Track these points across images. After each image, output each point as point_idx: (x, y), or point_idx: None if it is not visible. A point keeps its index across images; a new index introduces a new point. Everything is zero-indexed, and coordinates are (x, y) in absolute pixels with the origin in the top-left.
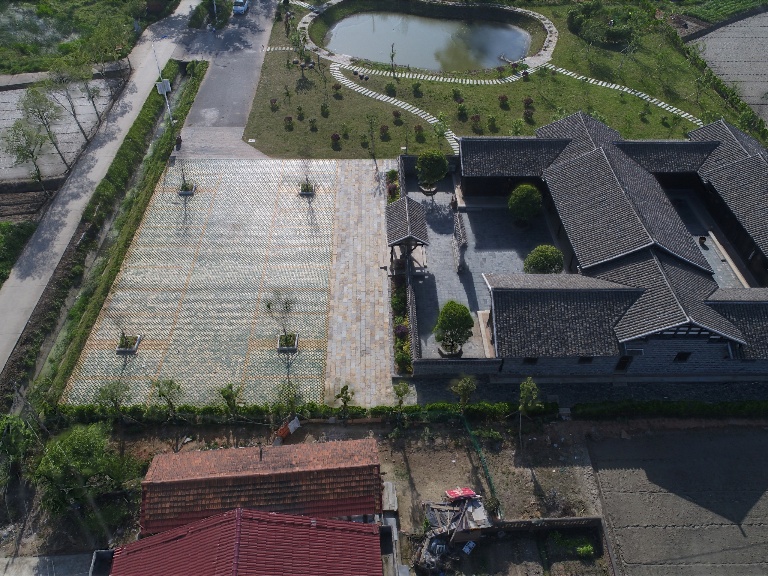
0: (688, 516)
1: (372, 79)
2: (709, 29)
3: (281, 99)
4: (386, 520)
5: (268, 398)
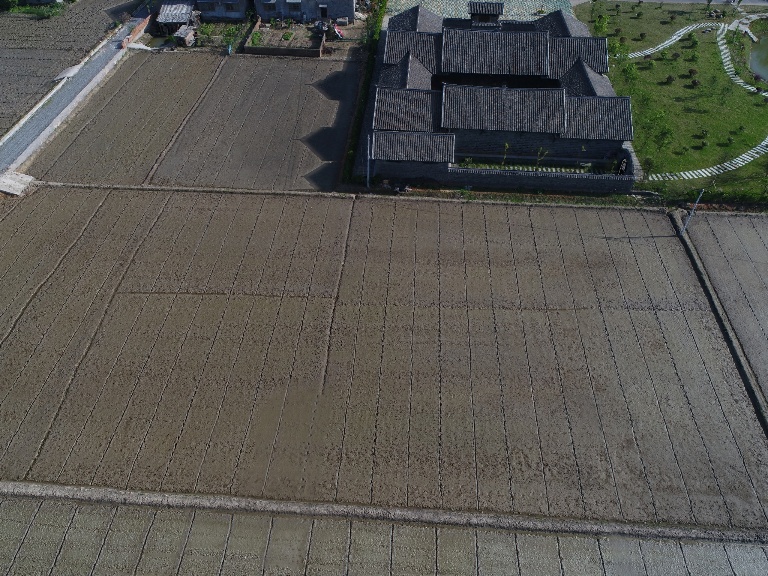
0: (318, 75)
1: (704, 34)
2: None
3: (650, 7)
4: (326, 4)
5: (392, 7)
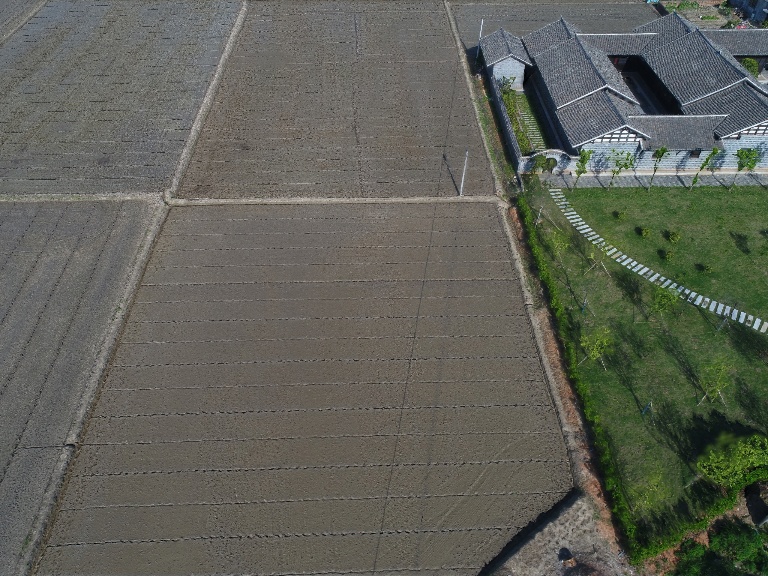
0: None
1: None
2: (495, 570)
3: None
4: None
5: None
